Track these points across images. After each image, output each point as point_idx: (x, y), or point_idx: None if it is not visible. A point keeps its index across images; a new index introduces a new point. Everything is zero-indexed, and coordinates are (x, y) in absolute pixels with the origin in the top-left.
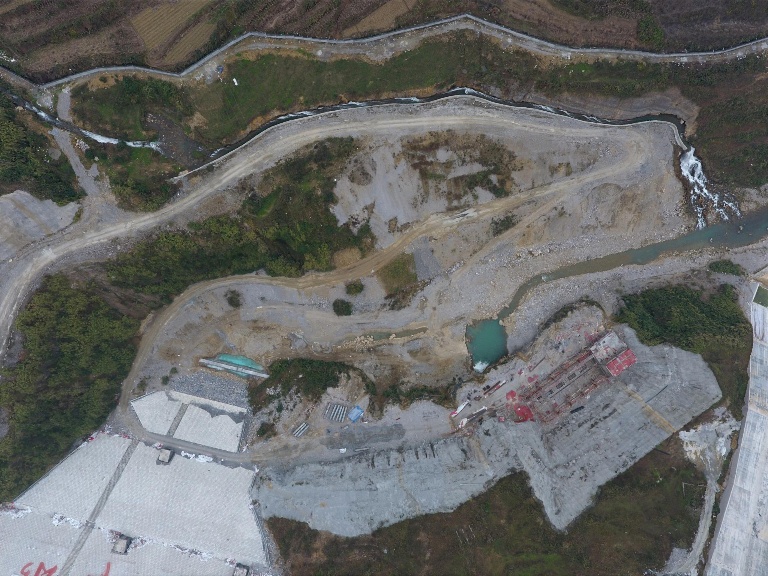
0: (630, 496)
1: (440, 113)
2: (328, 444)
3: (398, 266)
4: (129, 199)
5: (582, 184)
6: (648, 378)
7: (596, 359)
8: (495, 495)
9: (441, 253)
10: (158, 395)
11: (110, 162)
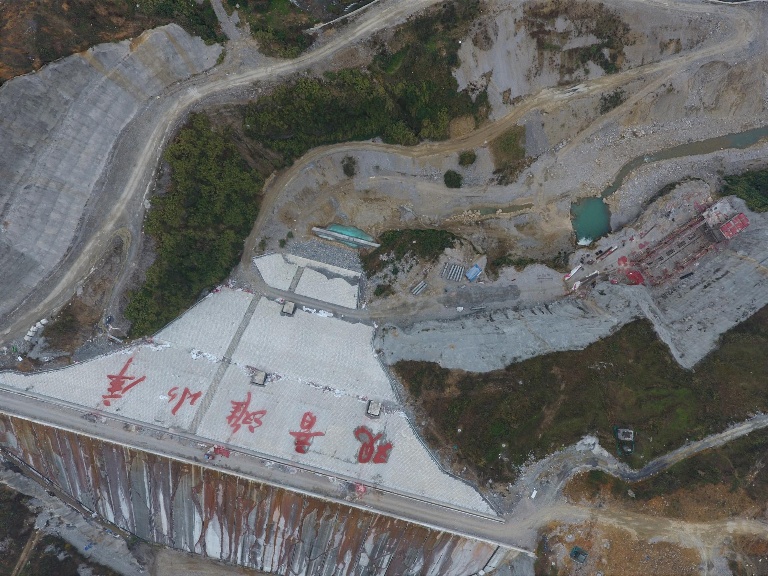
0: (753, 341)
1: None
2: (445, 303)
3: (510, 137)
4: (269, 45)
5: (691, 61)
6: (759, 243)
7: (708, 224)
8: (622, 338)
9: (550, 128)
10: (276, 257)
11: (250, 10)
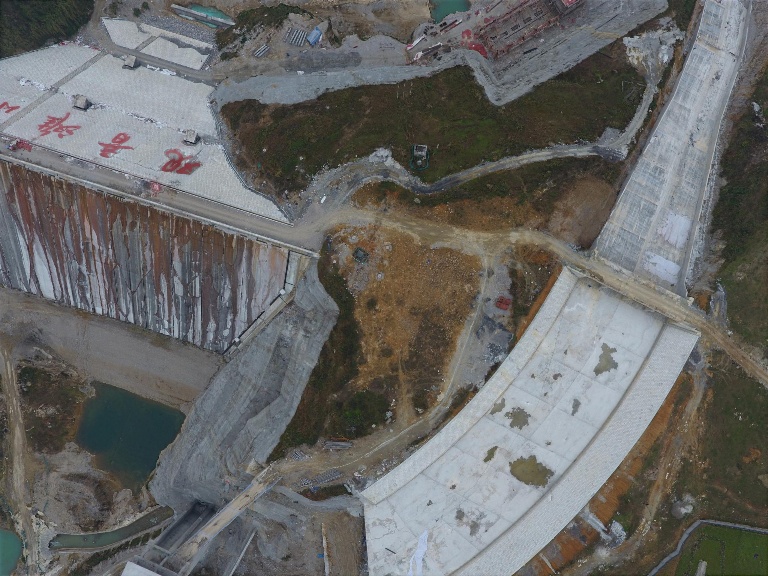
0: (569, 86)
1: None
2: (287, 67)
3: None
4: None
5: None
6: (601, 16)
7: None
8: (438, 79)
9: None
10: (129, 24)
11: None
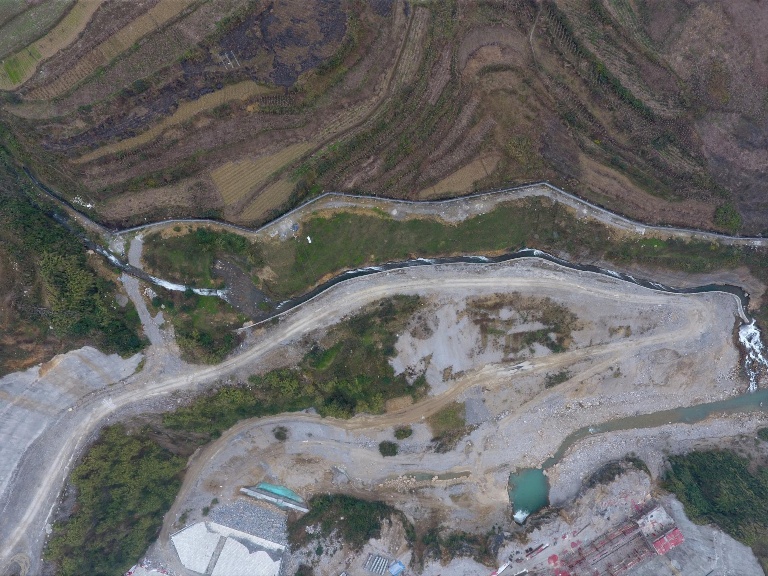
0: None
1: (507, 274)
2: None
3: (449, 414)
4: (193, 351)
5: (640, 347)
6: (693, 557)
7: (642, 533)
8: None
9: (492, 402)
10: (198, 527)
11: (176, 311)
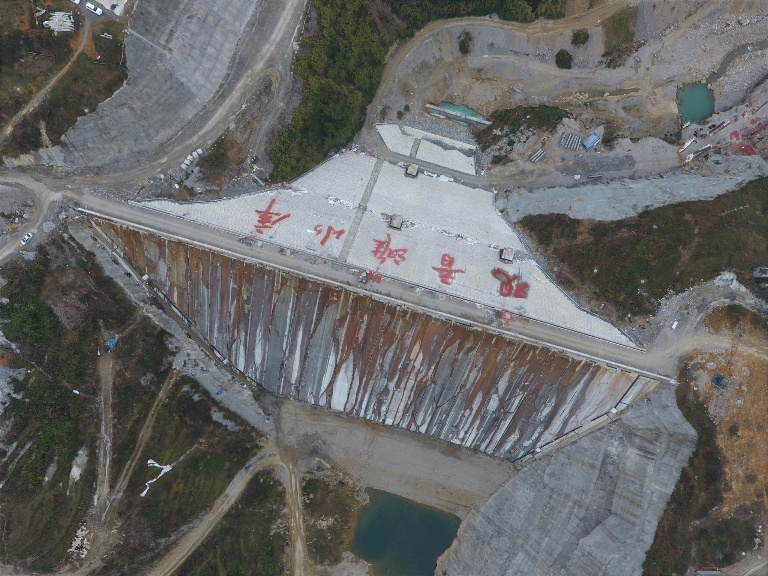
0: None
1: None
2: (563, 171)
3: (623, 17)
4: None
5: None
6: None
7: None
8: (748, 192)
9: (661, 11)
10: (394, 127)
11: None
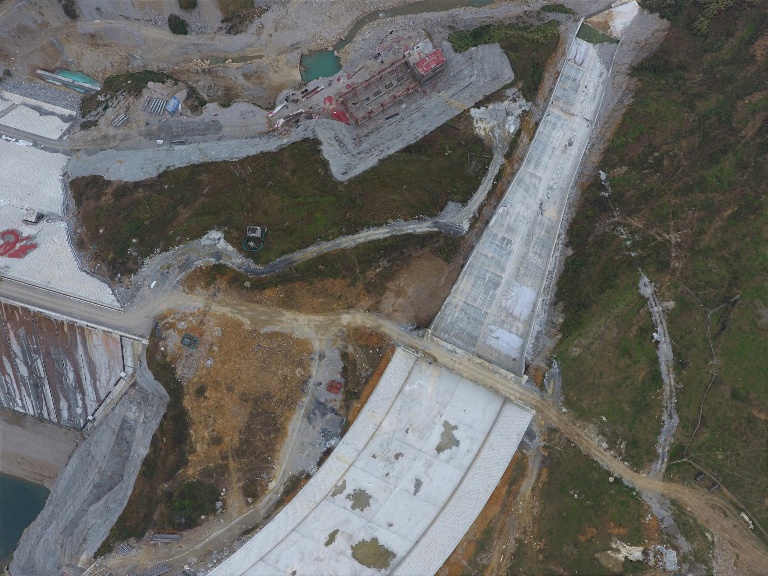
0: (414, 159)
1: None
2: (146, 135)
3: None
4: None
5: None
6: (458, 82)
7: (409, 63)
8: (284, 153)
9: None
10: None
11: None
